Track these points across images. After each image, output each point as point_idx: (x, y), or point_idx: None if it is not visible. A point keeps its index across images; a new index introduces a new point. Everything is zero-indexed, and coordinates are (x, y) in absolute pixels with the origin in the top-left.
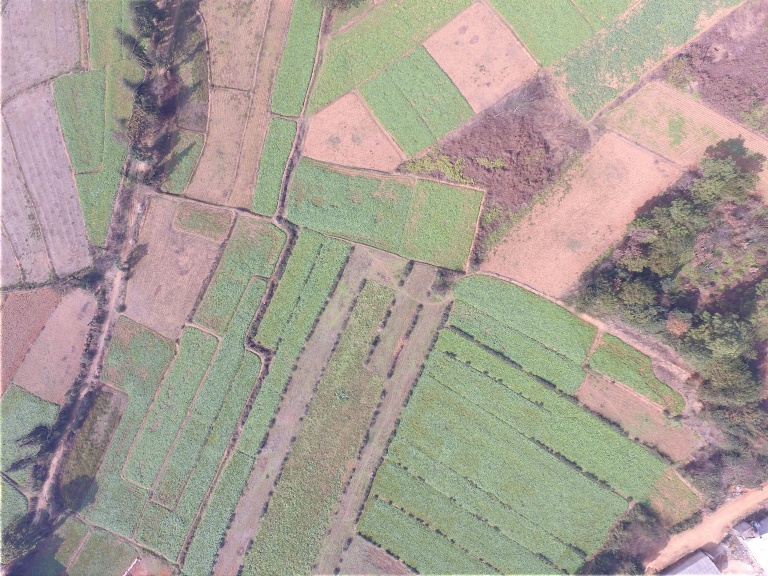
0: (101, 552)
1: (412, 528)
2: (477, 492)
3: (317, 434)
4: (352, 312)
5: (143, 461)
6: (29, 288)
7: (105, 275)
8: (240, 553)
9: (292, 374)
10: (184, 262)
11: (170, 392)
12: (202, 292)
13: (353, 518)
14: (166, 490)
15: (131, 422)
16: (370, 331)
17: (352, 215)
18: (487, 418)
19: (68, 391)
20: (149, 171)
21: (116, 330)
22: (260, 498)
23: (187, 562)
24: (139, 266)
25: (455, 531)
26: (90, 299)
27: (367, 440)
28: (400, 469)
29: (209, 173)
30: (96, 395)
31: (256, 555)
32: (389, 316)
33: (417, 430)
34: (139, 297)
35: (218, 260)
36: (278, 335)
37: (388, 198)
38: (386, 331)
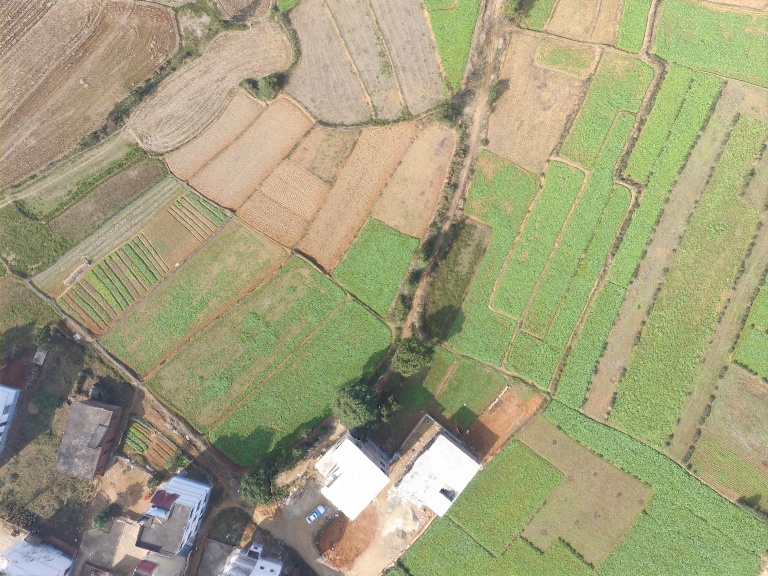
0: (470, 380)
1: None
2: None
3: (691, 265)
4: (725, 146)
5: (511, 291)
6: (383, 124)
7: (464, 111)
8: (613, 381)
9: (664, 206)
10: (547, 98)
11: (537, 224)
12: (569, 126)
13: (728, 347)
14: (536, 320)
15: (497, 254)
16: (744, 164)
17: (724, 50)
18: None
19: (433, 223)
20: (507, 7)
21: (479, 164)
22: (632, 328)
23: (561, 388)
24: (501, 101)
25: None
26: (447, 135)
27: (744, 270)
28: None
29: (570, 9)
30: (461, 227)
31: (630, 382)
32: (765, 149)
33: None
34: (502, 131)
35: (584, 95)
36: (649, 168)
37: (761, 33)
38: (761, 164)
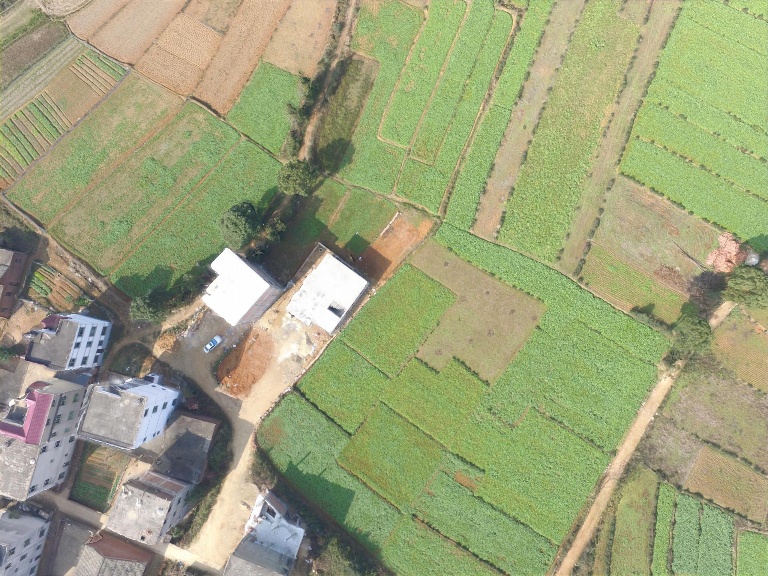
0: (361, 209)
1: (676, 165)
2: (741, 125)
3: (573, 83)
4: None
5: (399, 121)
6: None
7: None
8: (502, 200)
9: (545, 28)
10: None
11: (422, 55)
12: None
13: (614, 160)
14: (424, 146)
15: (384, 86)
16: None
17: None
18: (748, 54)
19: (320, 60)
20: None
21: (364, 1)
22: (518, 148)
23: (450, 210)
24: None
25: (720, 164)
26: None
27: (626, 84)
28: (660, 109)
29: None
30: (348, 63)
31: (518, 200)
32: None
33: (677, 70)
34: None
35: None
36: None
37: None
38: None
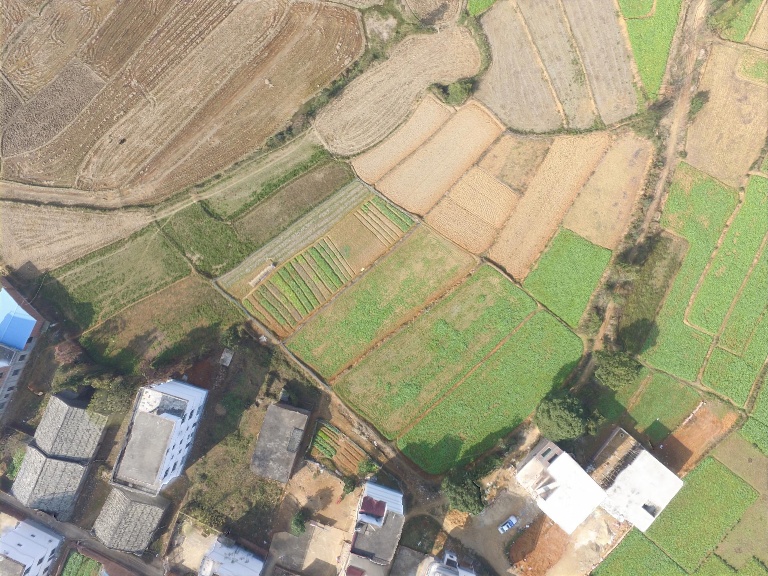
0: (663, 394)
1: None
2: None
3: None
4: None
5: (708, 307)
6: (576, 133)
7: (660, 122)
8: None
9: None
10: (747, 111)
11: (735, 240)
12: None
13: None
14: (733, 336)
15: (693, 268)
16: None
17: None
18: None
19: (628, 235)
20: (707, 18)
21: (676, 176)
22: None
23: (758, 406)
24: (700, 113)
25: None
26: (642, 146)
27: None
28: None
29: None
30: (656, 240)
31: None
32: None
33: None
34: (700, 144)
35: None
36: None
37: None
38: None
